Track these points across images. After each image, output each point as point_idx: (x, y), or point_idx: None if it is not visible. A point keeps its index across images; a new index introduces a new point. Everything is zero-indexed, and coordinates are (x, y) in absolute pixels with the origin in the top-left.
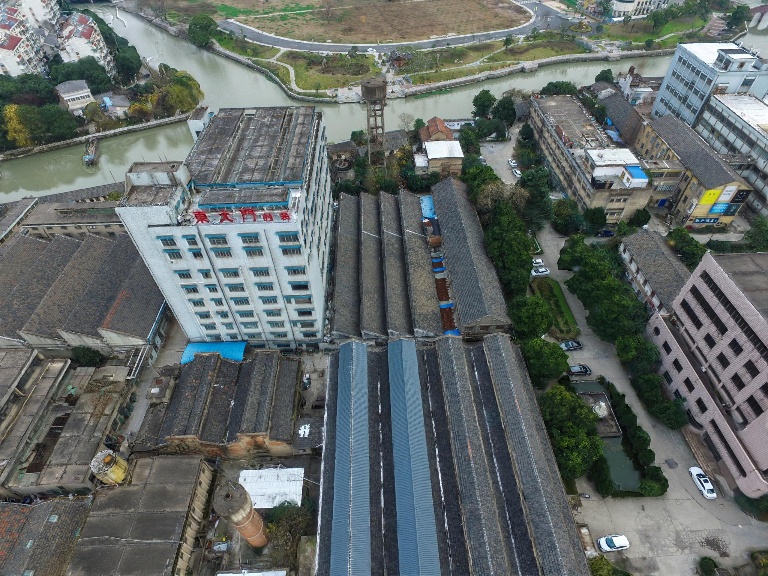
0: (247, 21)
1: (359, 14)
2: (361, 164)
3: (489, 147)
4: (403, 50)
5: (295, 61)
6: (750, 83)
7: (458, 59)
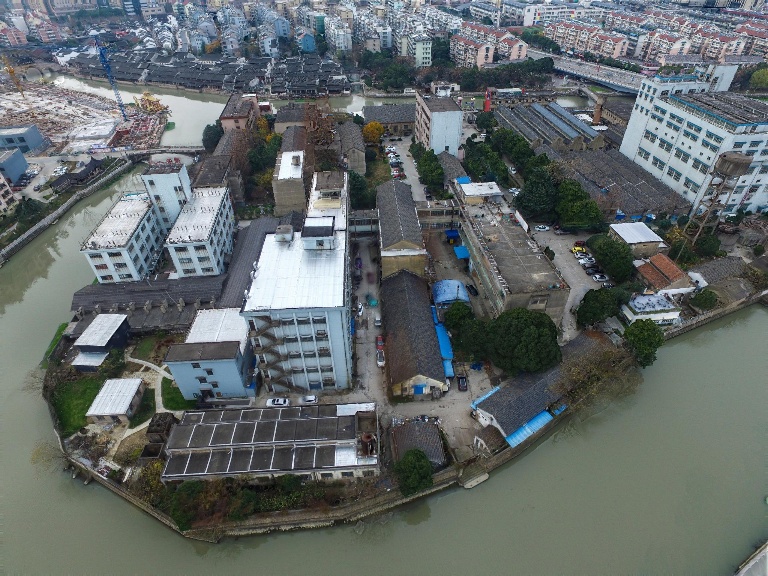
0: None
1: None
2: None
3: None
4: None
5: None
6: None
7: None
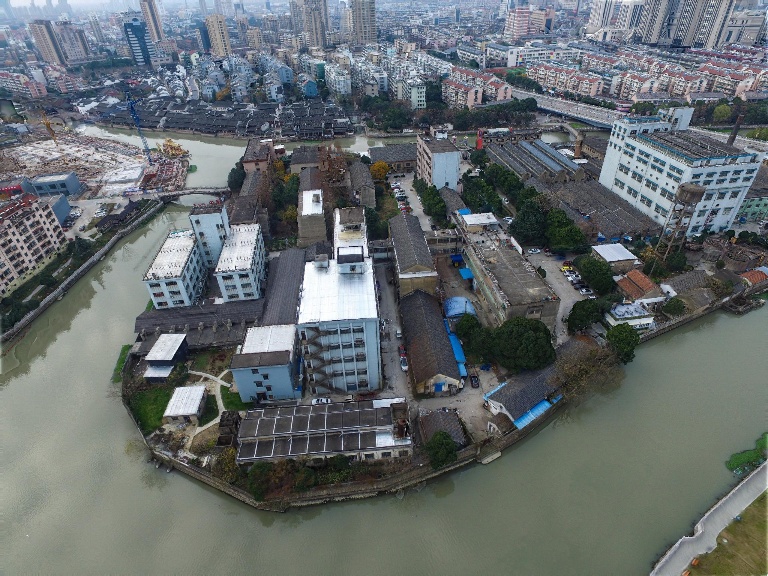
0: None
1: None
2: None
3: None
4: None
5: None
6: None
7: None
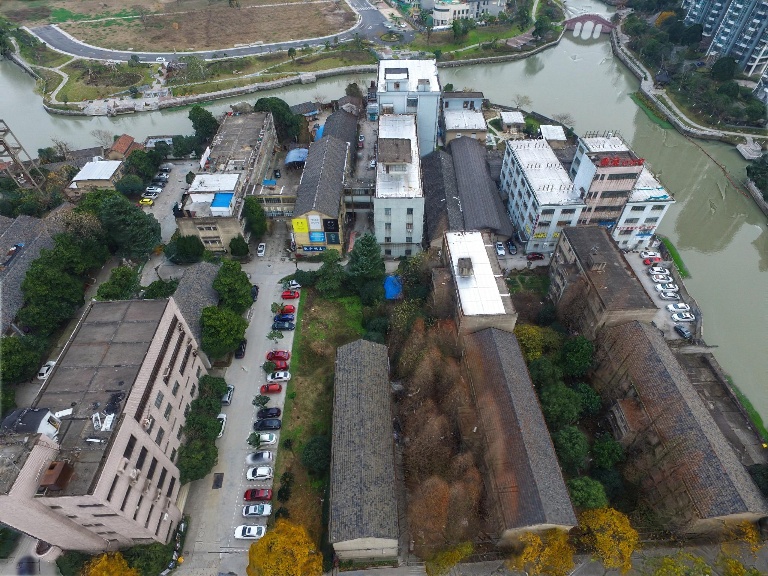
0: (68, 27)
1: (186, 20)
2: (4, 186)
3: (187, 165)
4: (185, 60)
5: (74, 70)
6: (416, 103)
7: (237, 70)
